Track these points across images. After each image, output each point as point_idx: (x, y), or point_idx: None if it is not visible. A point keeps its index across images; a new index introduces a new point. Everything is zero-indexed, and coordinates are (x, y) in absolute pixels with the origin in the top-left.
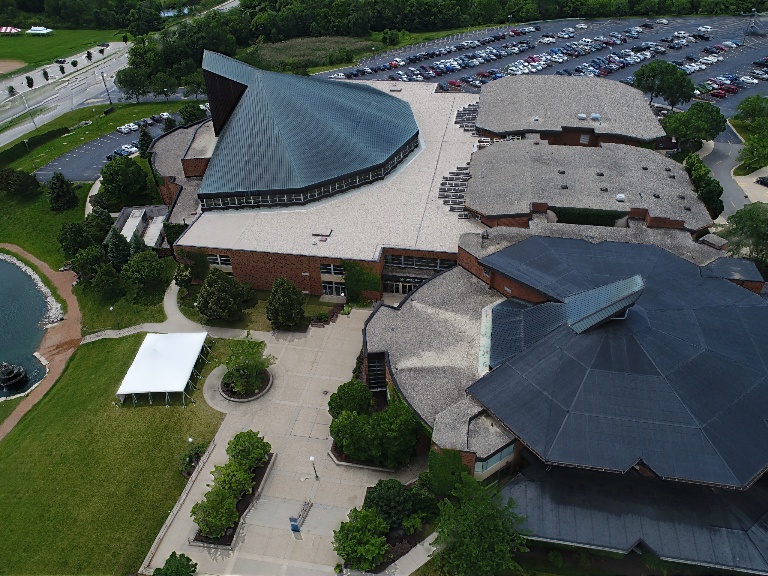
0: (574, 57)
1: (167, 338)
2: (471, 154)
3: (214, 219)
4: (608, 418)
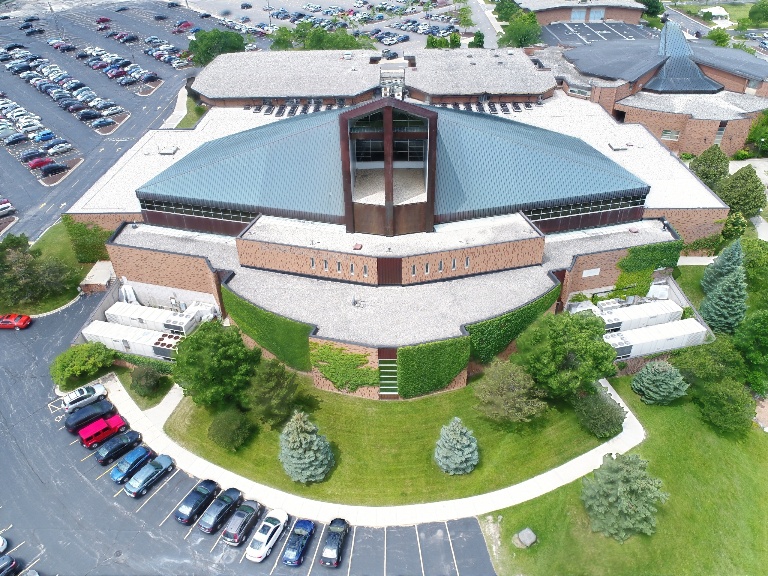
0: (5, 98)
1: None
2: (433, 94)
3: (652, 199)
4: (741, 57)
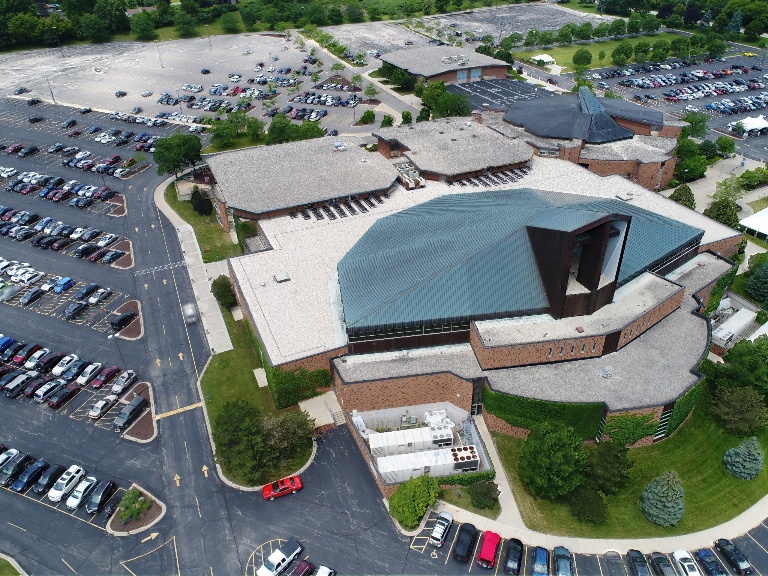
0: None
1: None
2: (452, 175)
3: None
4: None
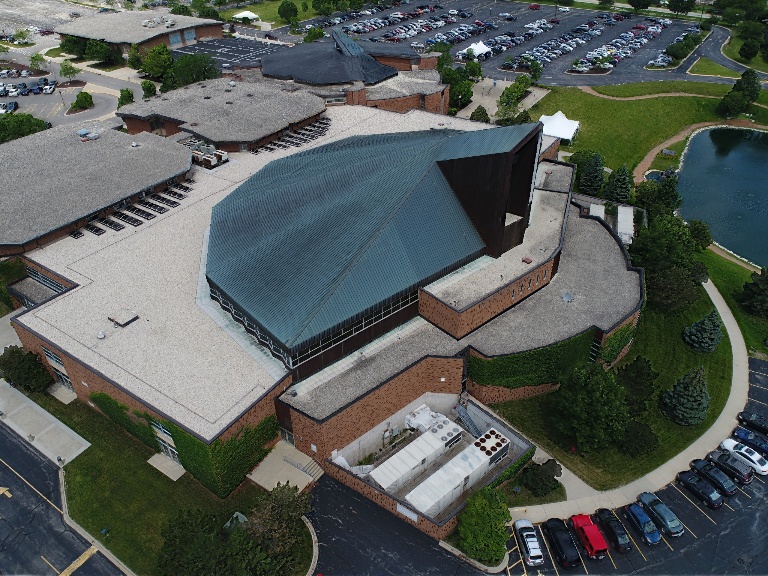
0: None
1: (554, 118)
2: (255, 140)
3: None
4: None
